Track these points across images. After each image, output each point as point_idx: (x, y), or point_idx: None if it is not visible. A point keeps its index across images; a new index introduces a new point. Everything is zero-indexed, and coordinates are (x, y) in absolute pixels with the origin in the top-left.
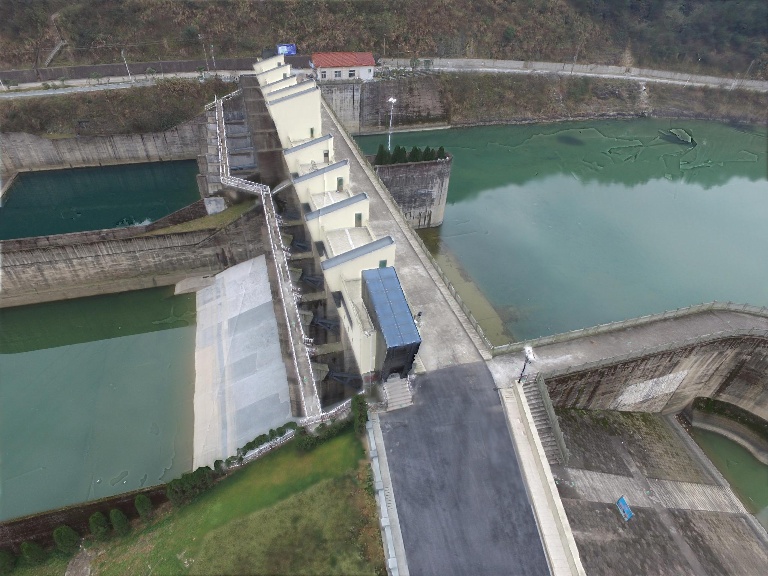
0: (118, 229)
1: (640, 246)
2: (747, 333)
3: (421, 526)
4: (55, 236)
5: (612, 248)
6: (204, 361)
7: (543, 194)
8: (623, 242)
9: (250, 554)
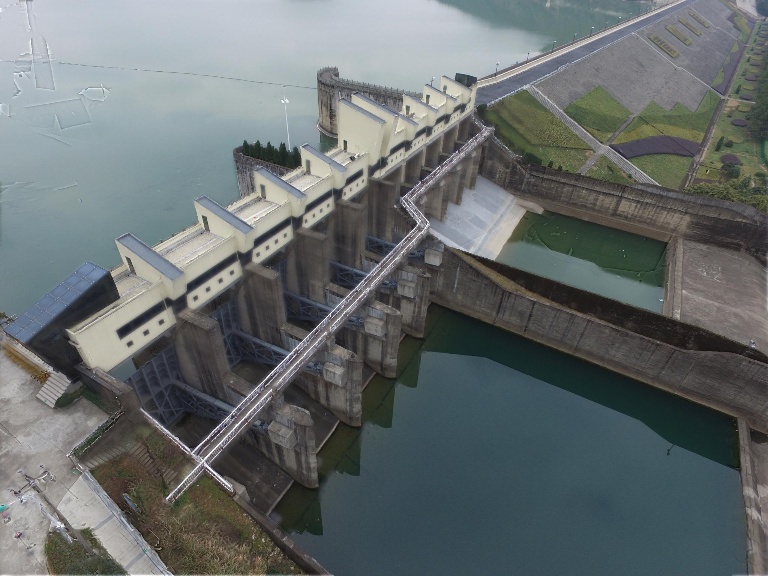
0: (533, 298)
1: (194, 151)
2: (338, 80)
3: (487, 100)
4: (599, 321)
5: (208, 157)
6: (496, 246)
7: (131, 191)
8: (194, 155)
9: (525, 129)
